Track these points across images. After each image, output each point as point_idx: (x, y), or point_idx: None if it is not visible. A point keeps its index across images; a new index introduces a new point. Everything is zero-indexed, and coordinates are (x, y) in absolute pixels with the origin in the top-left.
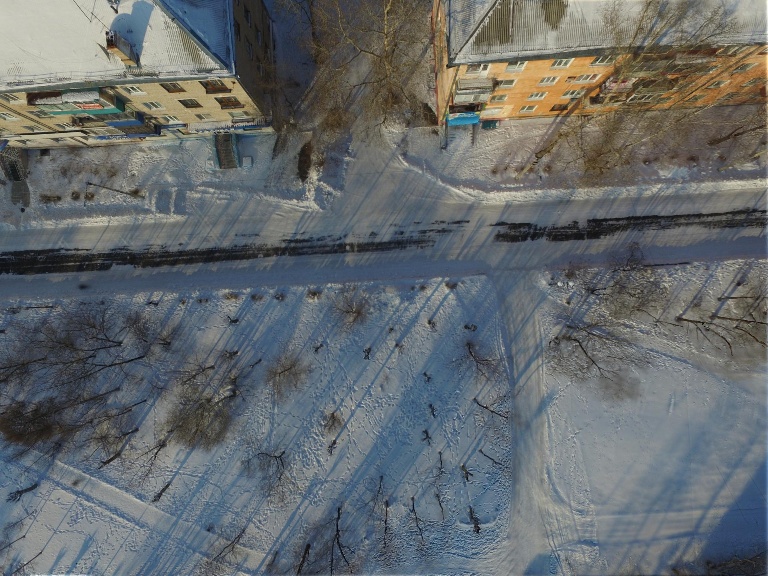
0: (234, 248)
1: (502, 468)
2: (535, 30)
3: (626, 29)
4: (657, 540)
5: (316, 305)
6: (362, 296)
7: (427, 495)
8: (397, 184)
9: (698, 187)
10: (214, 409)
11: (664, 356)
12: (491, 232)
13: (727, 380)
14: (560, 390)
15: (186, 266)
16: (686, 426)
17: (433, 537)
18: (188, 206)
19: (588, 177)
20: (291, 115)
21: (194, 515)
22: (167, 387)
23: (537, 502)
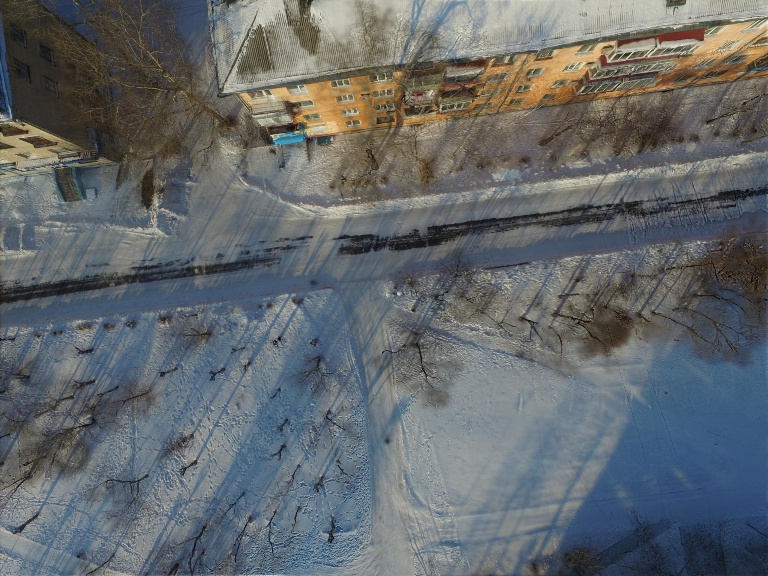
0: (86, 279)
1: (360, 476)
2: (293, 56)
3: (384, 49)
4: (516, 536)
5: (168, 329)
6: (212, 317)
7: (289, 508)
8: (240, 205)
9: (532, 188)
10: (76, 438)
11: (510, 356)
12: (334, 246)
13: (573, 375)
14: (411, 396)
15: (40, 300)
16: (536, 423)
17: (298, 548)
18: (37, 241)
19: (425, 185)
20: (130, 144)
21: (64, 543)
22: (29, 420)
23: (397, 507)
